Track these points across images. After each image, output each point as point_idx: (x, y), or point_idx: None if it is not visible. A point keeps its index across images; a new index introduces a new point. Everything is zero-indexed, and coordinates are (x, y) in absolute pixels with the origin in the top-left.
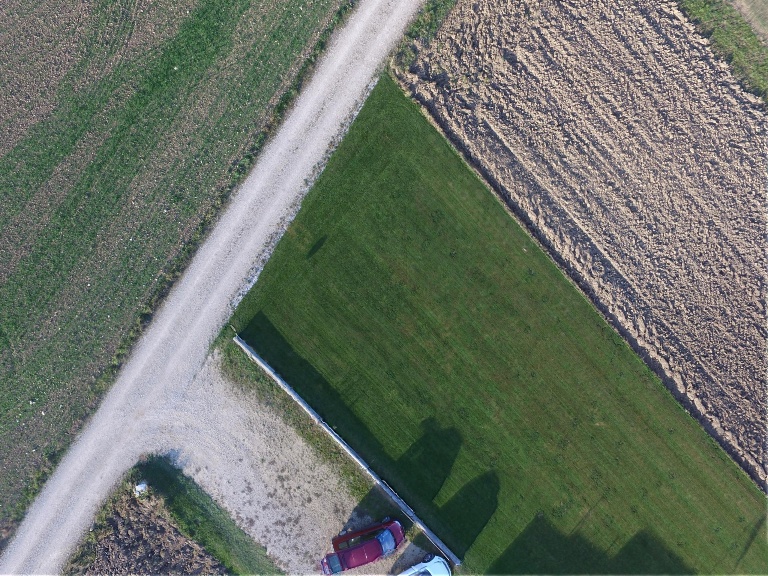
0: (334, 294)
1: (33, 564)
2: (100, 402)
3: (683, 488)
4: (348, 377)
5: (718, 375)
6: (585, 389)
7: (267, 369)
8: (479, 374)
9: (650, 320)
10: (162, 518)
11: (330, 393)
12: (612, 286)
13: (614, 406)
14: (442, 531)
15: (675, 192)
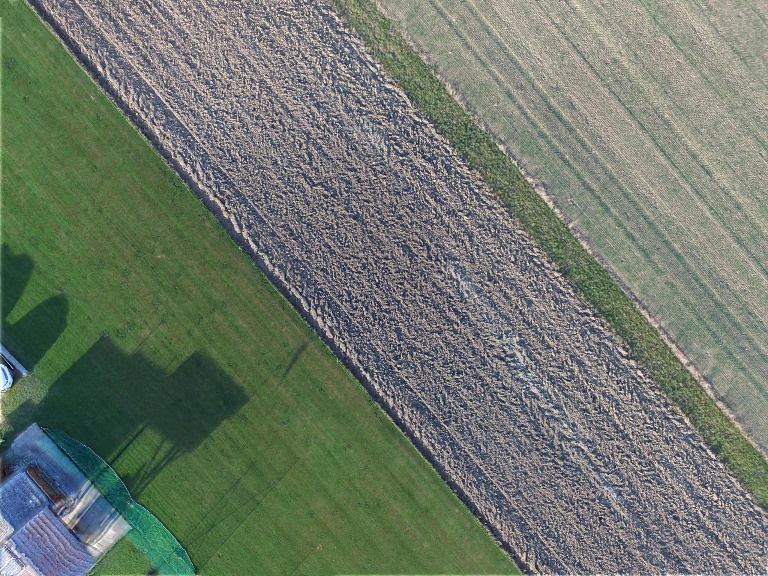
0: None
1: None
2: None
3: (235, 316)
4: None
5: (270, 218)
6: (148, 225)
7: None
8: (51, 207)
9: (208, 166)
10: None
11: None
12: (172, 133)
13: (175, 241)
14: (13, 345)
15: (229, 52)
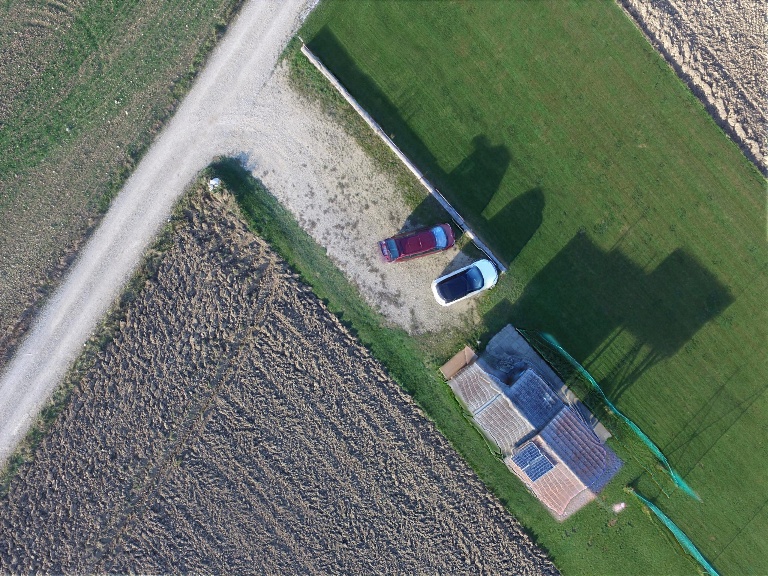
0: (395, 10)
1: (117, 249)
2: (178, 105)
3: (720, 209)
4: (406, 89)
5: (759, 102)
6: (630, 112)
7: (332, 76)
8: (529, 95)
9: (695, 46)
10: (233, 214)
11: (389, 107)
12: (660, 11)
13: (657, 129)
14: (489, 242)
15: None
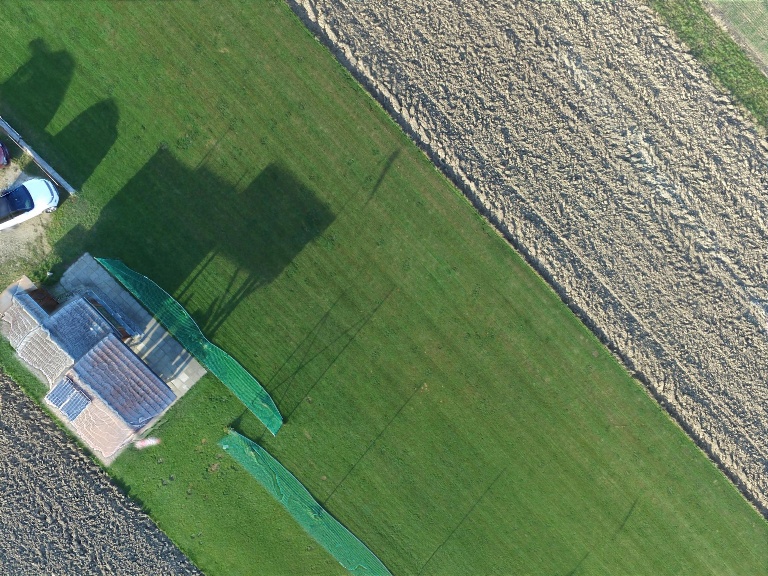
0: None
1: None
2: None
3: (314, 119)
4: None
5: (350, 2)
6: (207, 13)
7: None
8: None
9: None
10: None
11: None
12: None
13: (240, 33)
14: (56, 160)
15: None
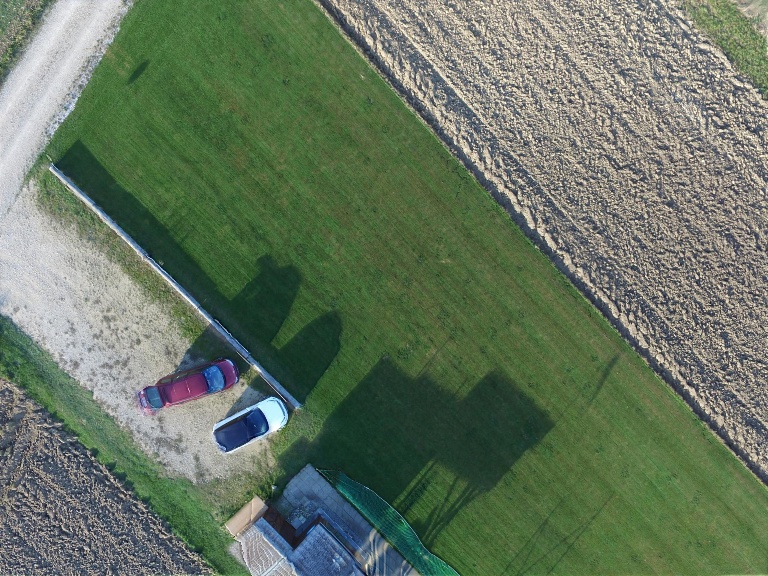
0: (158, 122)
1: None
2: None
3: (533, 327)
4: (175, 210)
5: (569, 209)
6: (430, 224)
7: (85, 200)
8: (317, 209)
9: (497, 152)
10: None
11: (158, 229)
12: (455, 115)
13: (461, 243)
14: (281, 374)
15: (519, 15)
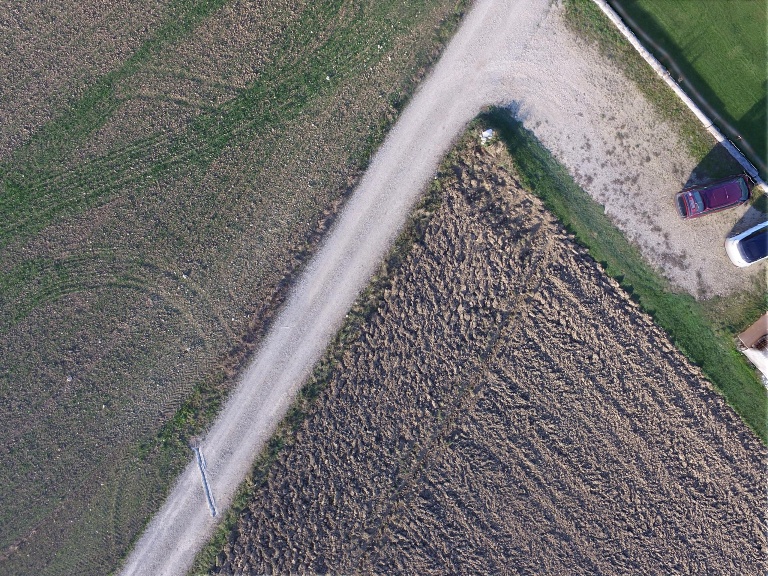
0: None
1: (379, 210)
2: (442, 51)
3: None
4: (696, 27)
5: None
6: None
7: (616, 14)
8: None
9: None
10: (504, 169)
11: (673, 47)
12: None
13: None
14: None
15: None
